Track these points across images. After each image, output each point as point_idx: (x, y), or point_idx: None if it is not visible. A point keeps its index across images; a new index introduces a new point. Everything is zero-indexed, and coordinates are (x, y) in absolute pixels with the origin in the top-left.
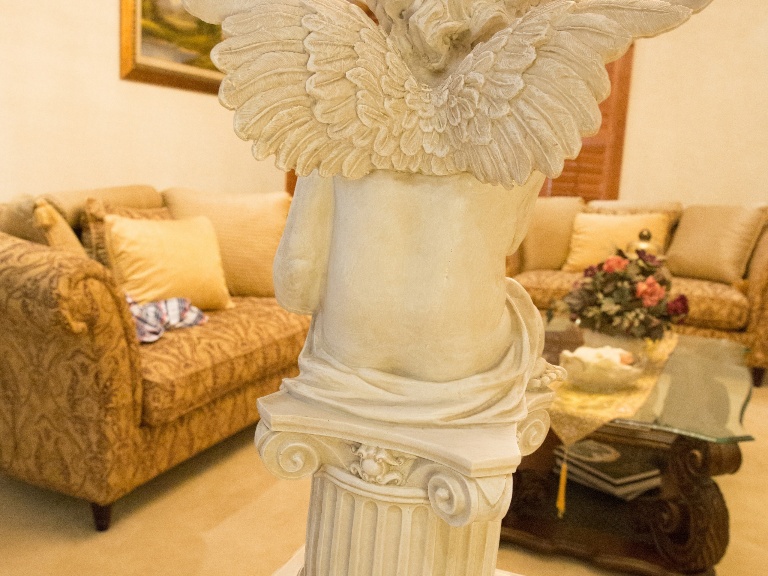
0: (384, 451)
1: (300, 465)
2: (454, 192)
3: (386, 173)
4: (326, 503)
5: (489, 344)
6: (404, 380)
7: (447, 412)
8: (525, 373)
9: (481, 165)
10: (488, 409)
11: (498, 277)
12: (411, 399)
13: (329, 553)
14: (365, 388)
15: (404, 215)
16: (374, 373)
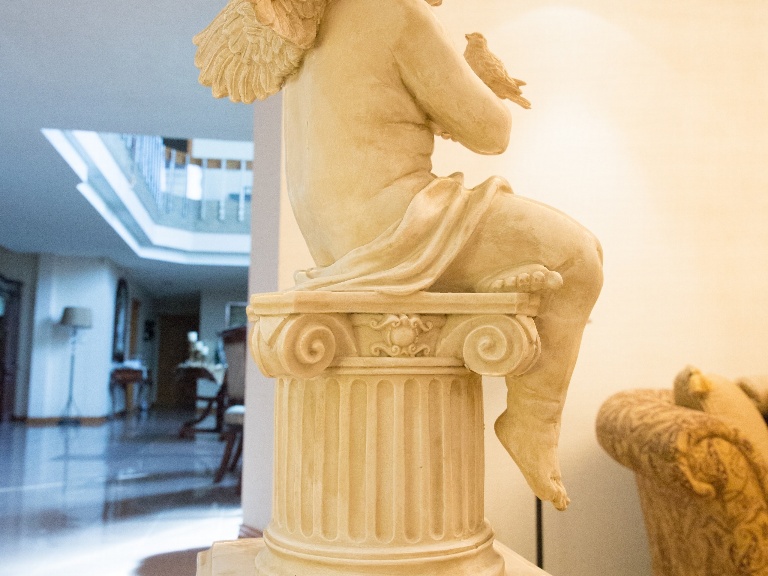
0: None
1: None
2: (306, 70)
3: None
4: None
5: (367, 215)
6: None
7: (314, 281)
8: (426, 251)
9: None
10: None
11: (362, 142)
12: None
13: None
14: None
15: (294, 108)
16: None
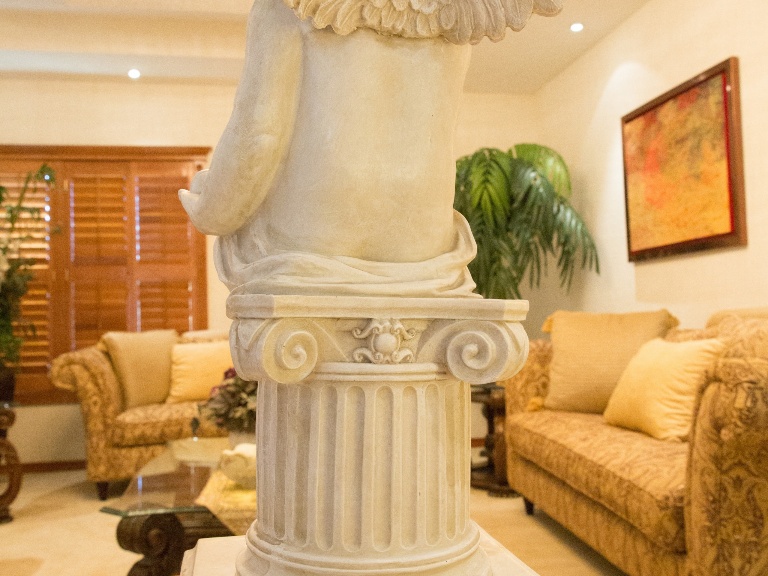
0: (399, 322)
1: (304, 358)
2: (431, 56)
3: (368, 33)
4: (319, 412)
5: (450, 224)
6: (383, 263)
7: (440, 282)
8: None
9: (473, 17)
10: (463, 285)
11: None
12: (396, 279)
13: (327, 473)
14: (351, 271)
15: (387, 77)
16: (352, 258)
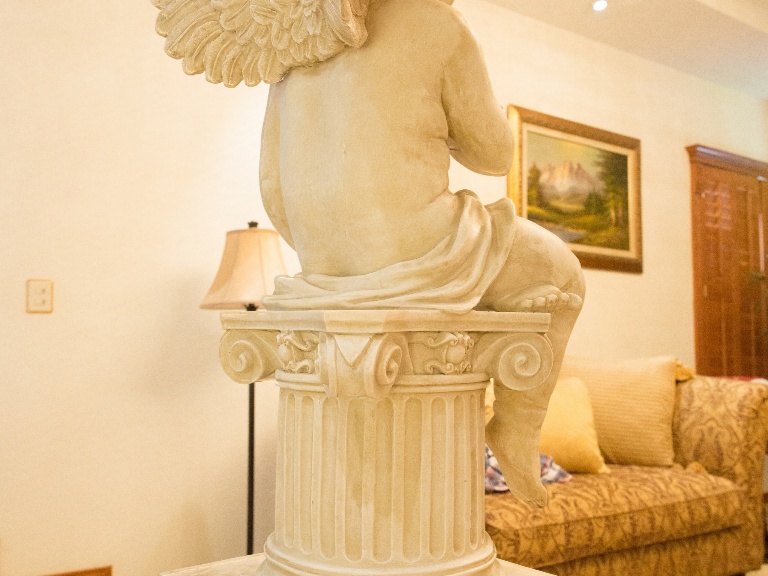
0: (292, 333)
1: (244, 363)
2: (344, 69)
3: (298, 71)
4: None
5: (413, 229)
6: (339, 278)
7: (356, 294)
8: (474, 270)
9: None
10: None
11: (410, 154)
12: None
13: None
14: (304, 288)
15: (312, 104)
16: (318, 275)
